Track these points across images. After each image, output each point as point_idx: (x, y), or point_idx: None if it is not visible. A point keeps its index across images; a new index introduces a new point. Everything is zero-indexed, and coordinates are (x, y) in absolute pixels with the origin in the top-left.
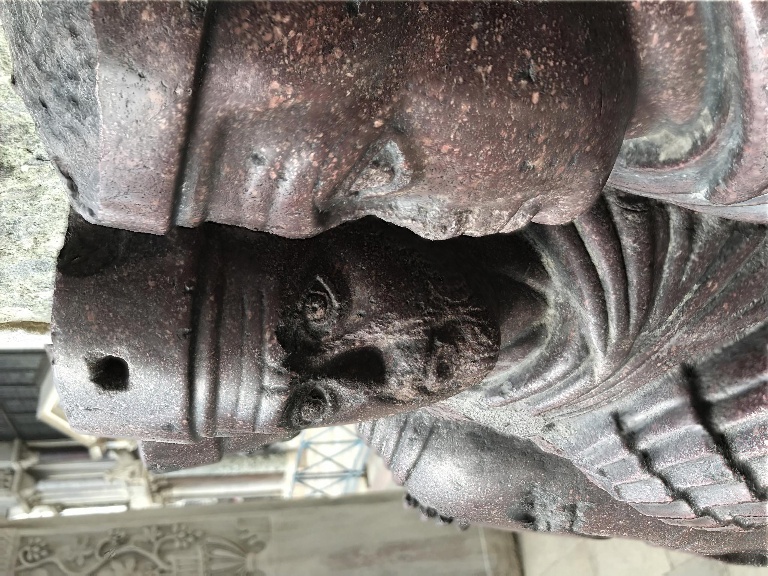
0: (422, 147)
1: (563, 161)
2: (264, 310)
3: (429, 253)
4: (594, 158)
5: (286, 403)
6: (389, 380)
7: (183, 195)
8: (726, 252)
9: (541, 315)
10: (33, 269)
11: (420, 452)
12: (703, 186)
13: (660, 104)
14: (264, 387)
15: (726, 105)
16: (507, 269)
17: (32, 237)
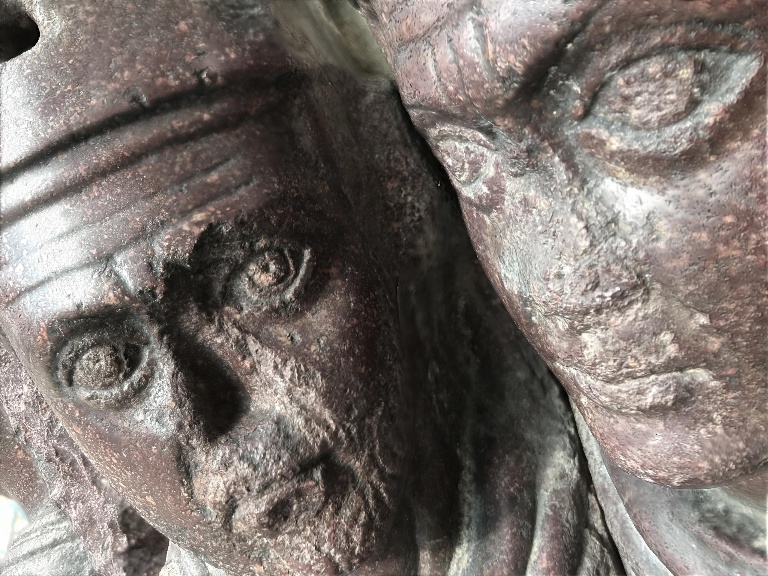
0: (766, 115)
1: None
2: (231, 194)
3: (406, 386)
4: None
5: (102, 308)
6: (220, 445)
7: None
8: None
9: None
10: None
11: None
12: None
13: None
14: (111, 259)
15: None
16: (422, 514)
17: None
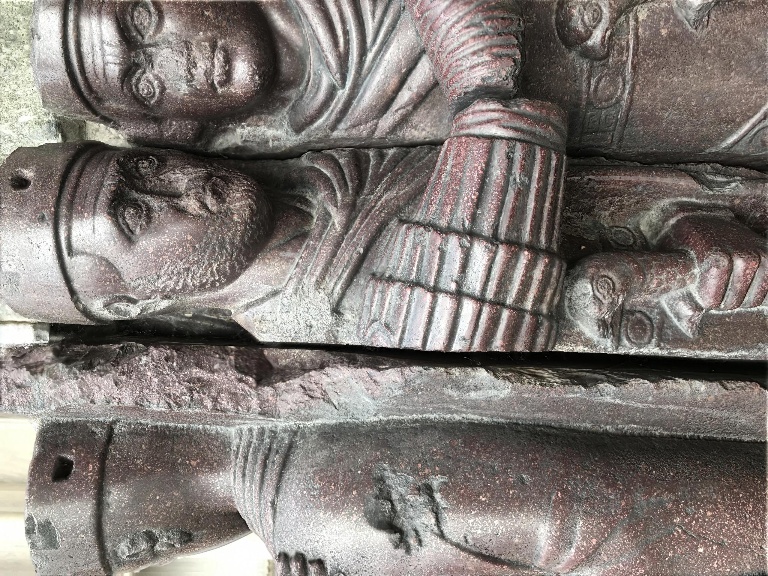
0: (159, 1)
1: (223, 17)
2: None
3: None
4: (243, 26)
5: (114, 193)
6: (182, 196)
7: (69, 12)
8: None
9: (310, 223)
10: None
11: (280, 470)
12: (328, 73)
13: (285, 33)
14: (103, 185)
15: None
16: (283, 199)
17: None
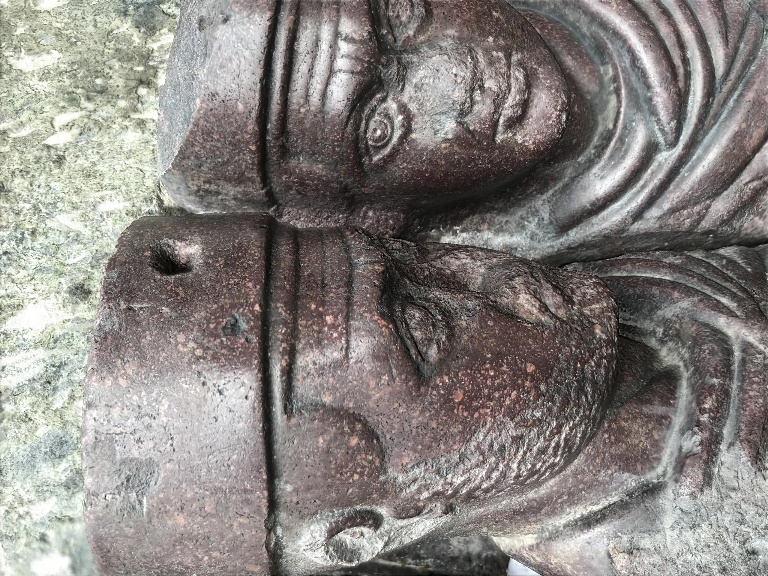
0: None
1: (517, 24)
2: None
3: None
4: None
5: (382, 278)
6: (498, 290)
7: None
8: (765, 256)
9: (656, 358)
10: (45, 454)
11: None
12: (651, 123)
13: (573, 73)
14: (353, 265)
15: (601, 41)
16: None
17: (69, 388)
